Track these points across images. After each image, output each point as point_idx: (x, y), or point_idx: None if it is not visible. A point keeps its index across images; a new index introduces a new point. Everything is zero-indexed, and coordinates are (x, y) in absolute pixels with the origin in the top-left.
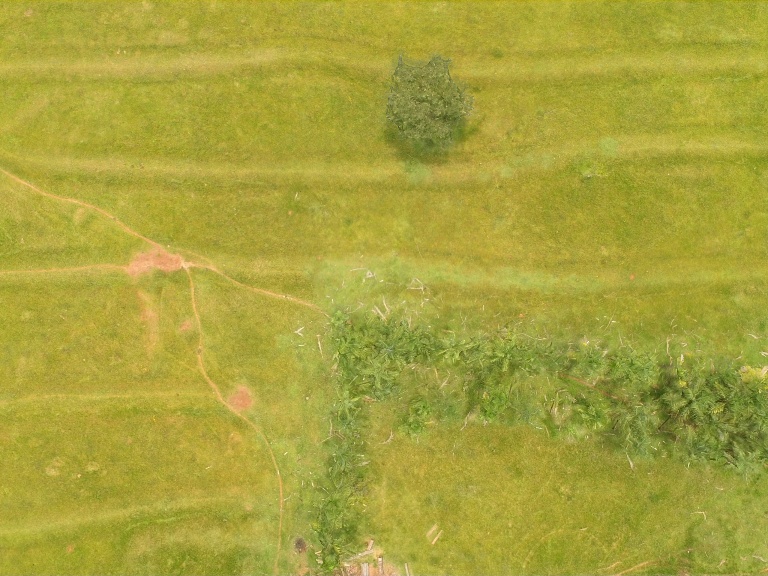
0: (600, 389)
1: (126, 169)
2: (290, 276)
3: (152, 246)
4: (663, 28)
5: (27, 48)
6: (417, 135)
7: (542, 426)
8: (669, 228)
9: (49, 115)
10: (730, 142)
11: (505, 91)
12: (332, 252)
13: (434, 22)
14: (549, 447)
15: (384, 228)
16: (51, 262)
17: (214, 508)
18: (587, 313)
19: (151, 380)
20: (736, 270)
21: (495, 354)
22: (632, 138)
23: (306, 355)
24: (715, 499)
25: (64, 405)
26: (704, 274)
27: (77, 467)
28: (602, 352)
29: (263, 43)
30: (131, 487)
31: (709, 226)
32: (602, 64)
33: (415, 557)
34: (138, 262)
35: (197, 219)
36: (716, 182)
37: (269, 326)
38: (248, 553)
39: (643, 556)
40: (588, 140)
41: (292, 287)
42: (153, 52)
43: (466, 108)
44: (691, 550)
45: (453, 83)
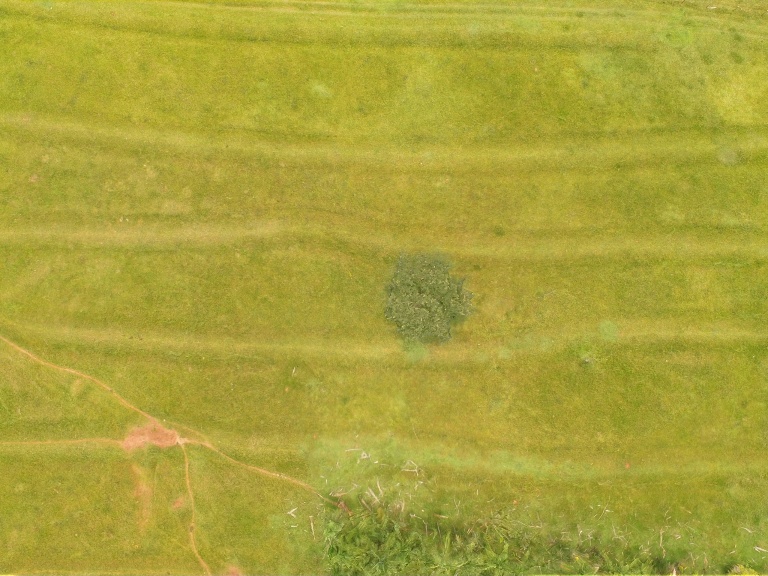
0: None
1: (125, 340)
2: (285, 455)
3: (148, 420)
4: (665, 210)
5: (30, 214)
6: (415, 337)
7: None
8: (666, 416)
9: (50, 282)
10: (729, 329)
11: (505, 270)
12: (328, 430)
13: (436, 197)
14: None
15: (380, 407)
16: (47, 434)
17: None
18: (581, 501)
19: (142, 557)
20: (732, 462)
21: (487, 565)
22: (631, 322)
23: (298, 536)
24: None
25: None
26: (700, 465)
27: None
28: (594, 568)
29: (265, 214)
30: None
31: (706, 415)
32: (603, 245)
33: None
34: (133, 437)
35: (194, 393)
36: (714, 370)
37: (262, 506)
38: None
39: None
40: (587, 323)
41: (286, 465)
42: (155, 221)
43: (465, 308)
44: None
45: (453, 285)
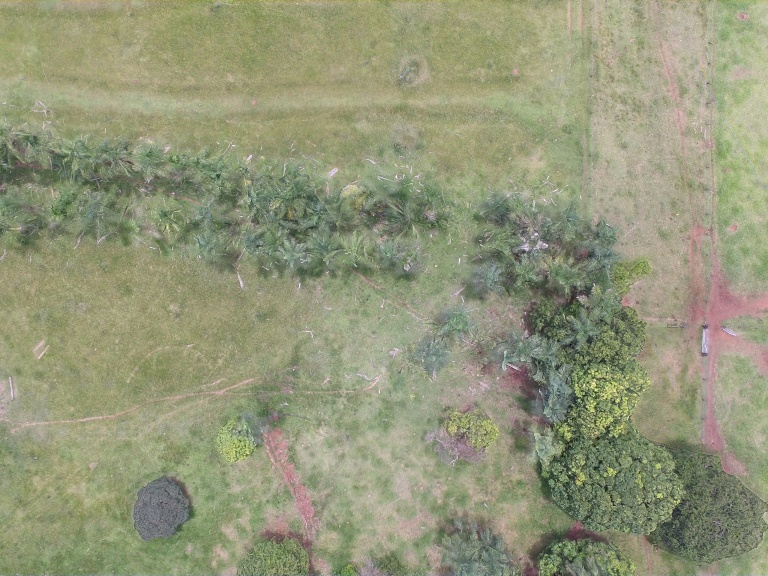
0: (215, 210)
1: None
2: None
3: None
4: None
5: None
6: None
7: (155, 246)
8: (295, 56)
9: None
10: None
11: None
12: None
13: None
14: (161, 266)
15: (11, 52)
16: None
17: None
18: (207, 137)
19: None
20: (358, 97)
21: (62, 151)
22: None
23: None
24: (323, 319)
25: None
26: (326, 100)
27: None
28: (164, 148)
29: None
30: None
31: (335, 54)
32: None
33: (20, 371)
34: None
35: None
36: (344, 12)
37: None
38: None
39: (248, 373)
40: None
41: None
42: None
43: None
44: (296, 368)
45: None
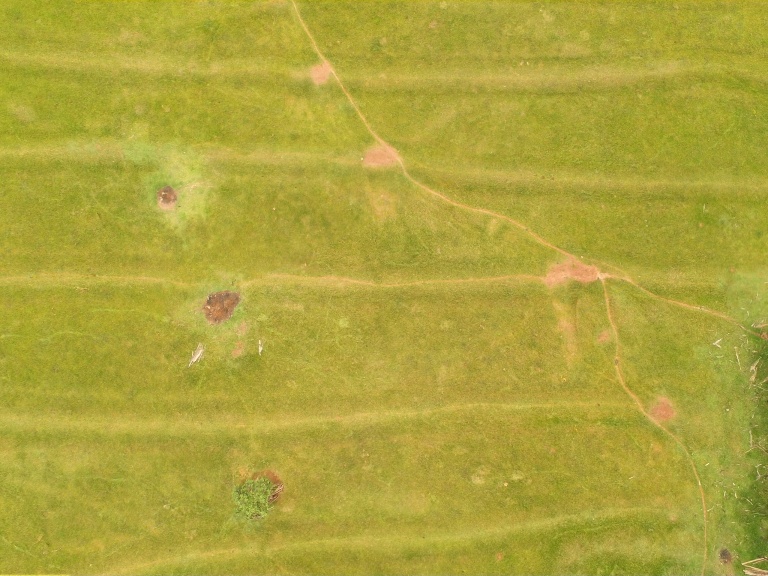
0: None
1: (537, 180)
2: (704, 288)
3: (566, 257)
4: None
5: (432, 59)
6: None
7: None
8: None
9: (457, 126)
10: None
11: None
12: (743, 264)
13: None
14: None
15: None
16: (468, 272)
17: (640, 518)
18: None
19: (570, 390)
20: None
21: None
22: None
23: (724, 367)
24: None
25: (487, 414)
26: None
27: (502, 475)
28: None
29: (663, 55)
30: (555, 496)
31: None
32: None
33: None
34: (555, 273)
35: (609, 230)
36: None
37: (687, 337)
38: (674, 563)
39: None
40: None
41: (706, 299)
42: (556, 64)
43: None
44: None
45: None
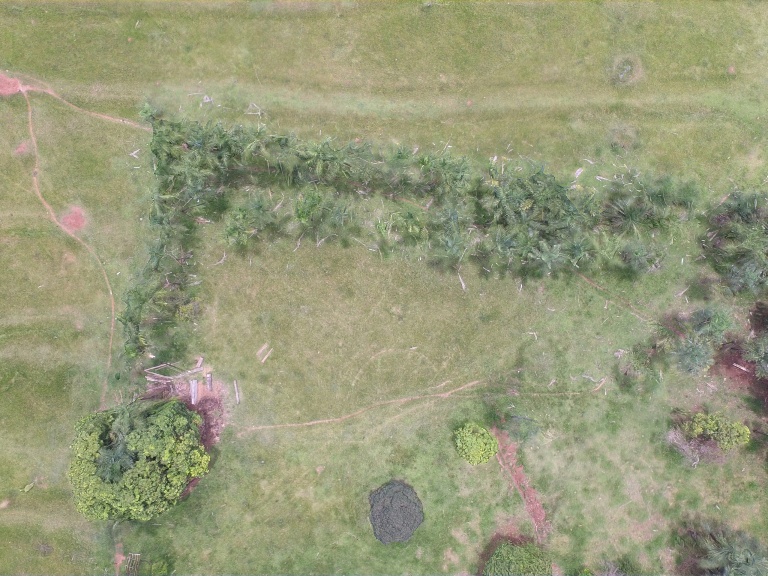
0: (434, 212)
1: None
2: (127, 100)
3: None
4: None
5: None
6: None
7: (375, 248)
8: (508, 56)
9: None
10: None
11: None
12: (171, 78)
13: None
14: (381, 268)
15: (223, 55)
16: None
17: (45, 325)
18: (423, 138)
19: None
20: (573, 96)
21: (308, 153)
22: None
23: (141, 177)
24: (547, 320)
25: None
26: (541, 100)
27: None
28: (412, 149)
29: None
30: None
31: (548, 54)
32: None
33: (244, 375)
34: None
35: (37, 45)
36: (556, 11)
37: (105, 148)
38: (78, 370)
39: (473, 375)
40: None
41: (129, 111)
42: None
43: None
44: (521, 370)
45: None
